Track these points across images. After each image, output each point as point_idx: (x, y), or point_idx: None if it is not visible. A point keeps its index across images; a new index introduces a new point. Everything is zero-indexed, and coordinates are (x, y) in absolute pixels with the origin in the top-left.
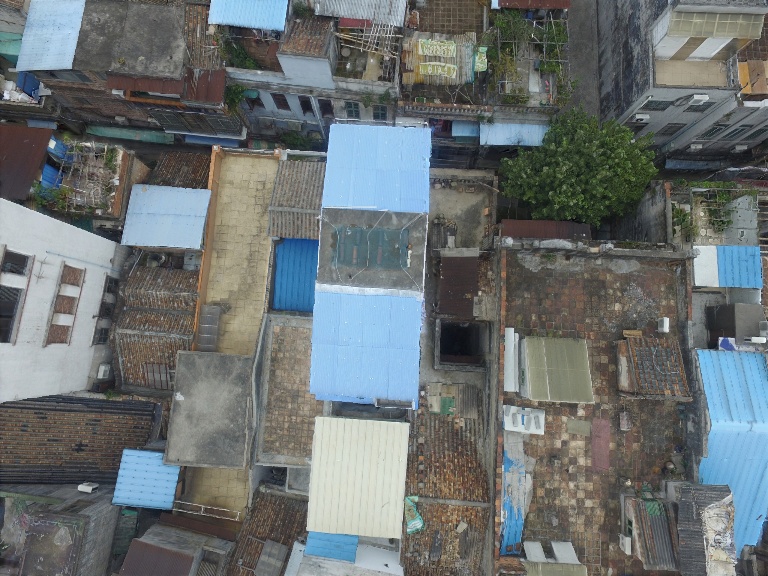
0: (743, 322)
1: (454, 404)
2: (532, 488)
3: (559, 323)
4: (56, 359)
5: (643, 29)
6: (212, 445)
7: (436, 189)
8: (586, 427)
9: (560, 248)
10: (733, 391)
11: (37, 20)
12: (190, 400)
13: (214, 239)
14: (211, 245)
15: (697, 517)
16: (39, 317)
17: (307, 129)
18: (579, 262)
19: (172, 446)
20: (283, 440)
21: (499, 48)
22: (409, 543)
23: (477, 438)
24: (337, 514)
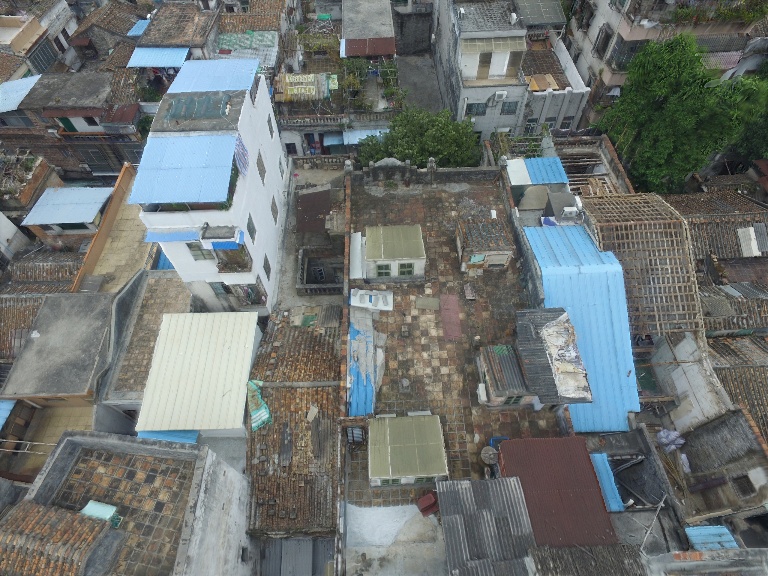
0: (558, 204)
1: (316, 319)
2: (384, 361)
3: None
4: None
5: (453, 65)
6: (57, 376)
7: (305, 170)
8: (434, 302)
9: (391, 165)
10: (559, 248)
11: (2, 91)
12: (46, 336)
13: (112, 229)
14: (108, 233)
15: (536, 336)
16: None
17: None
18: (417, 188)
19: (13, 381)
20: (139, 377)
21: (346, 74)
22: (255, 444)
23: (335, 339)
24: (173, 409)
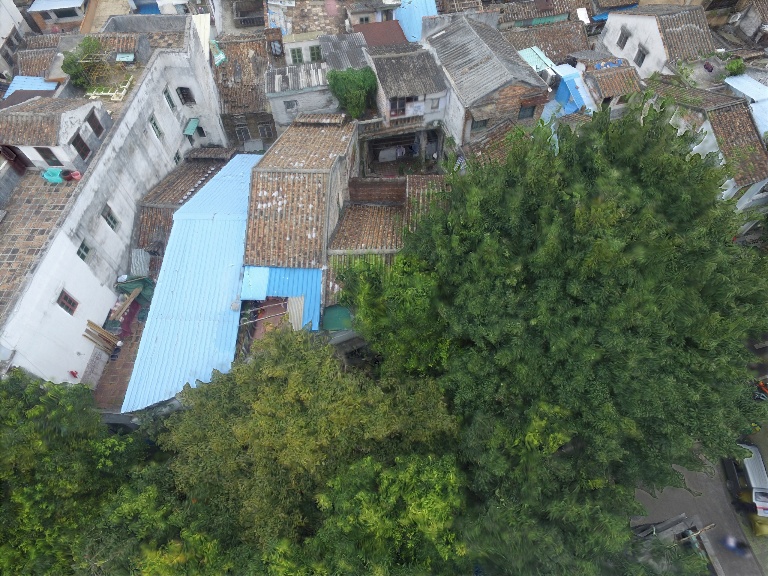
0: None
1: None
2: (292, 27)
3: None
4: None
5: None
6: None
7: None
8: (321, 3)
9: None
10: None
11: None
12: None
13: (94, 21)
14: (91, 23)
15: None
16: None
17: None
18: None
19: (52, 74)
20: None
21: None
22: (219, 73)
23: None
24: None
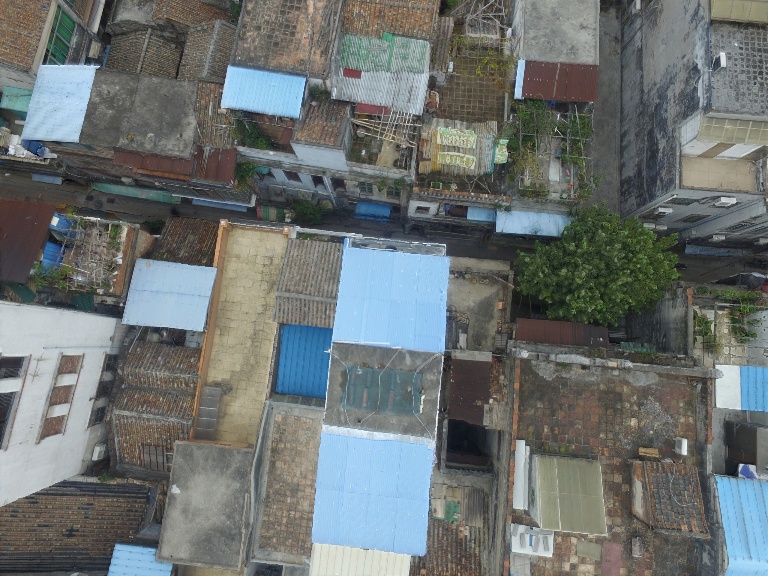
0: (765, 449)
1: (459, 509)
2: None
3: (572, 436)
4: (49, 452)
5: (671, 124)
6: (207, 542)
7: None
8: (596, 550)
9: (577, 363)
10: (752, 525)
11: (45, 87)
12: (186, 493)
13: (218, 316)
14: (214, 322)
15: None
16: (33, 415)
17: (318, 197)
18: (595, 372)
19: (166, 541)
20: (280, 536)
21: (521, 141)
22: None
23: (482, 550)
24: None
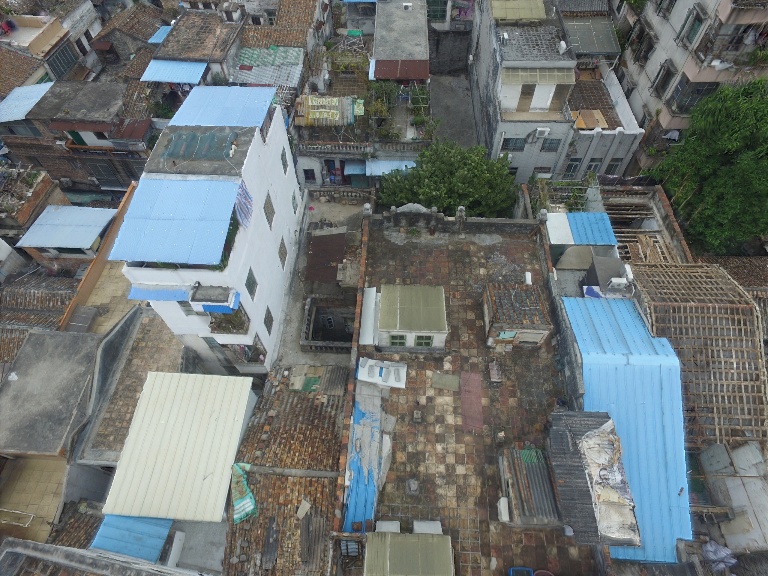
0: (604, 271)
1: (319, 383)
2: (391, 452)
3: None
4: None
5: (492, 94)
6: (29, 429)
7: (322, 203)
8: (454, 381)
9: (416, 212)
10: (603, 329)
11: (14, 97)
12: (24, 380)
13: None
14: None
15: (574, 448)
16: None
17: None
18: (443, 237)
19: None
20: (119, 434)
21: (373, 100)
22: (236, 540)
23: (338, 412)
24: (146, 490)
